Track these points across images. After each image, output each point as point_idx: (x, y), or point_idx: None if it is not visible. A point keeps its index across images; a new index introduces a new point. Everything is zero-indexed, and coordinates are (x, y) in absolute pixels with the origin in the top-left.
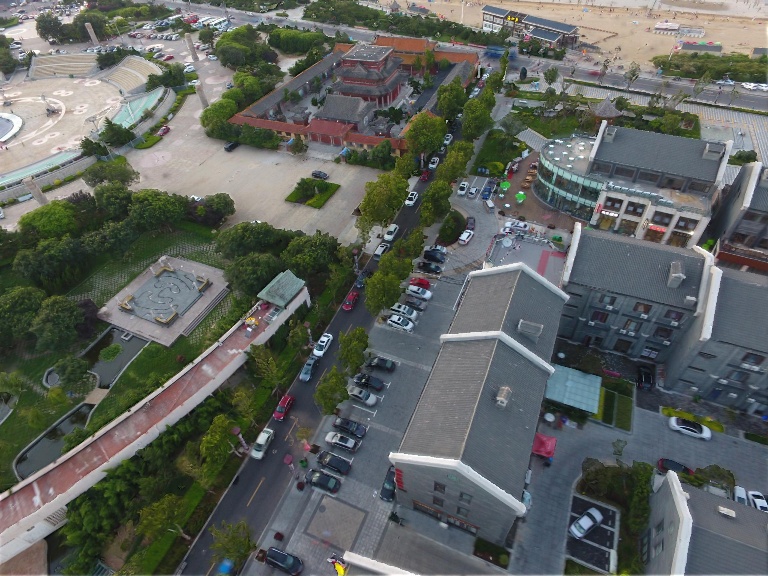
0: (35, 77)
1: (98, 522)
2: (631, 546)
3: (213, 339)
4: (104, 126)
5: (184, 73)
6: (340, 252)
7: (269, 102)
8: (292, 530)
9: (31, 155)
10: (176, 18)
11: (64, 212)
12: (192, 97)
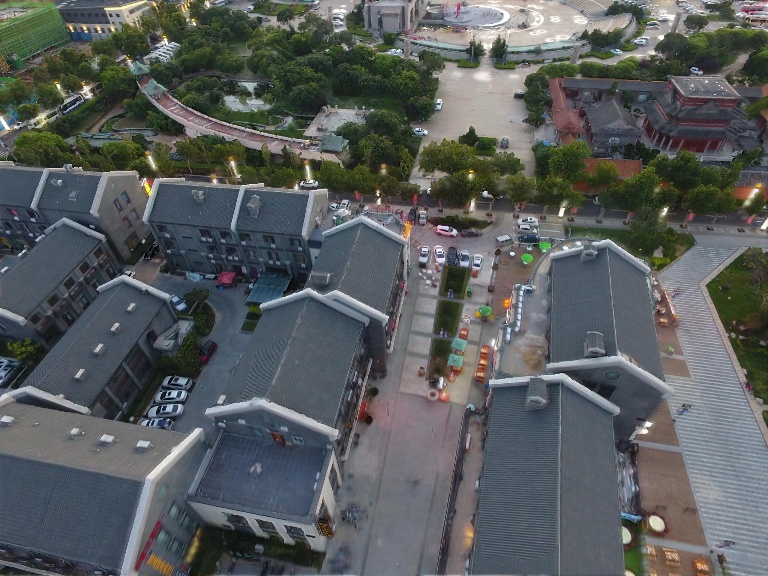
0: (568, 3)
1: (197, 144)
2: None
3: None
4: (495, 40)
5: (633, 43)
6: (365, 151)
7: (591, 84)
8: None
9: (467, 40)
10: (744, 2)
11: (388, 62)
12: (592, 59)
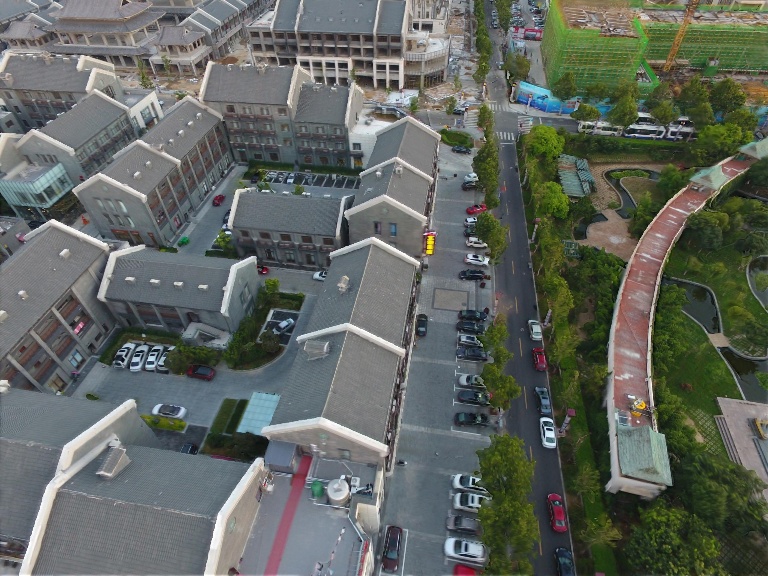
0: None
1: None
2: (256, 322)
3: (667, 394)
4: None
5: None
6: None
7: None
8: (477, 291)
9: None
10: None
11: None
12: None
